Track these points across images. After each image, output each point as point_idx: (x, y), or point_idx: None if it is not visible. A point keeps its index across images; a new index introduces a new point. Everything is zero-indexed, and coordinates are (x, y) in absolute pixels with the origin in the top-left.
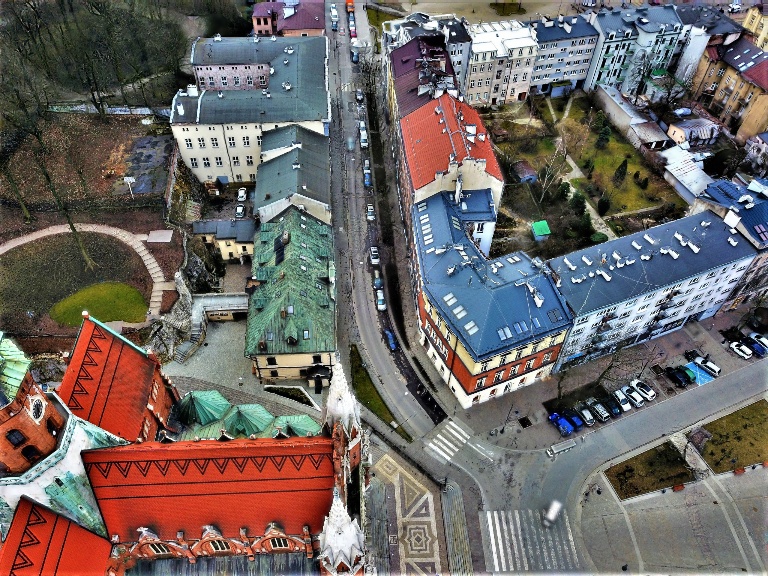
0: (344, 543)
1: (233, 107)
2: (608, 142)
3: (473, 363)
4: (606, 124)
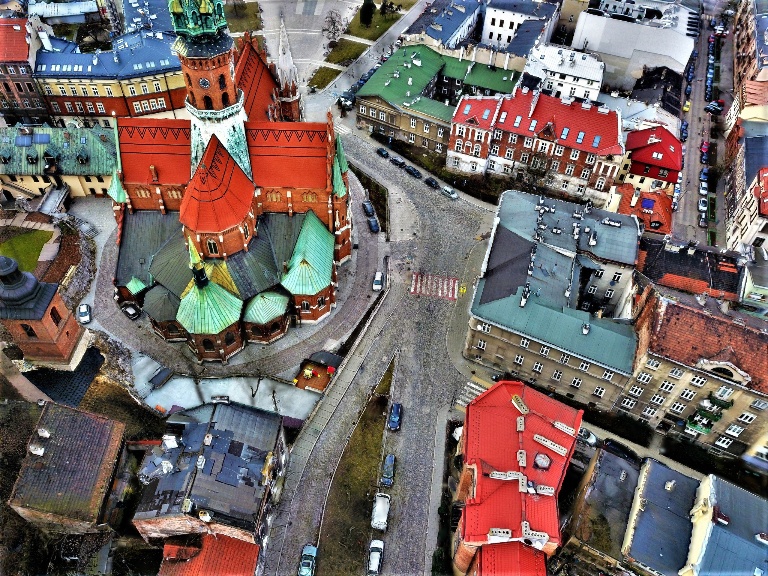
0: None
1: None
2: None
3: None
4: None
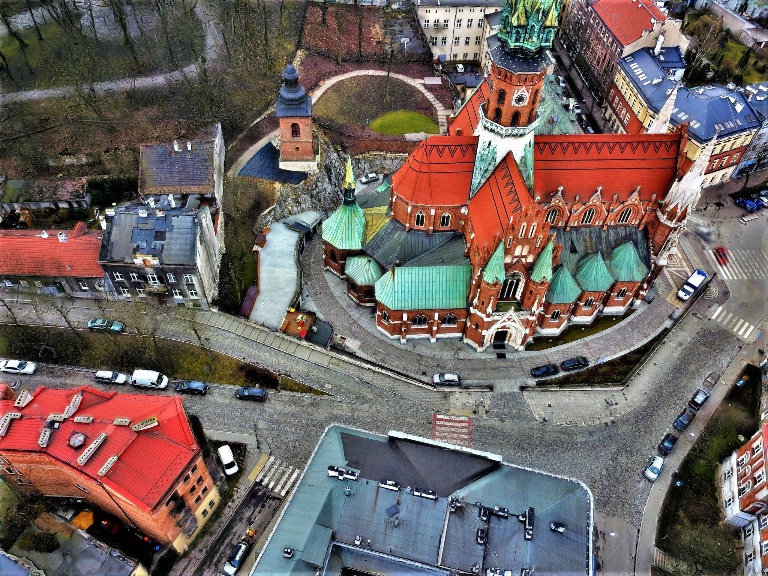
0: (697, 186)
1: None
2: (728, 41)
3: (696, 149)
4: (721, 30)
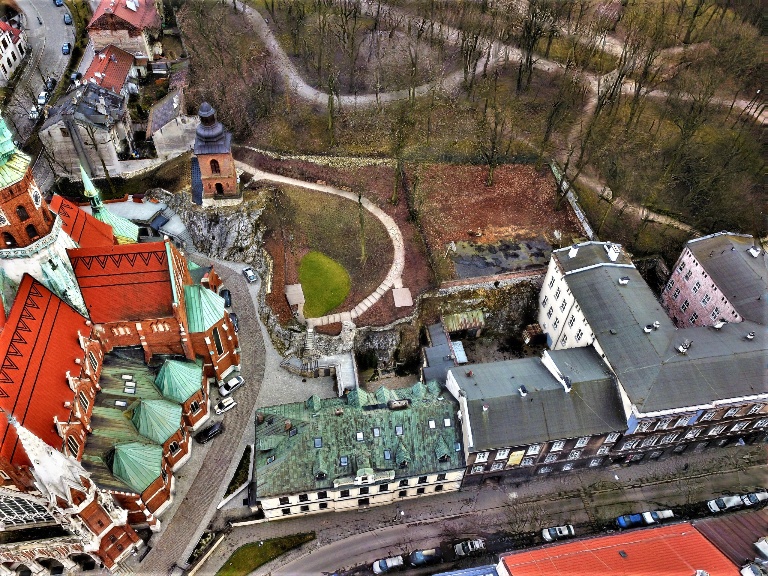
0: None
1: (608, 299)
2: None
3: None
4: None
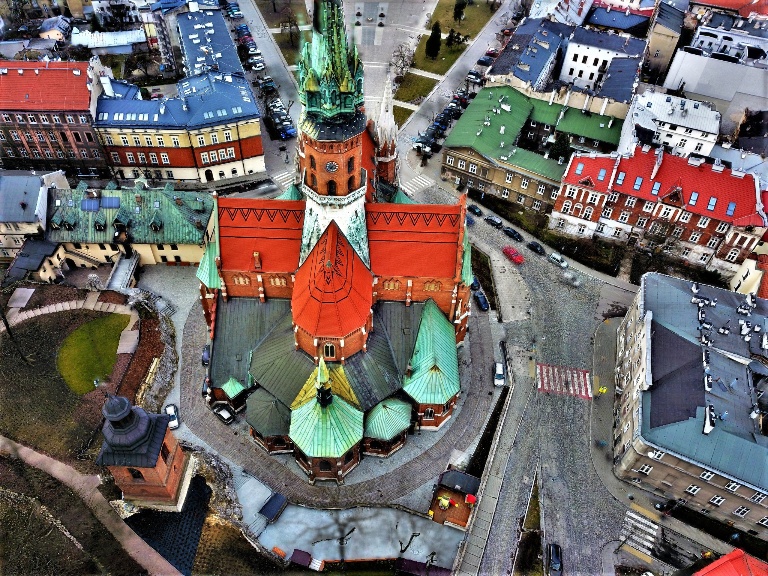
0: None
1: None
2: None
3: (257, 125)
4: None
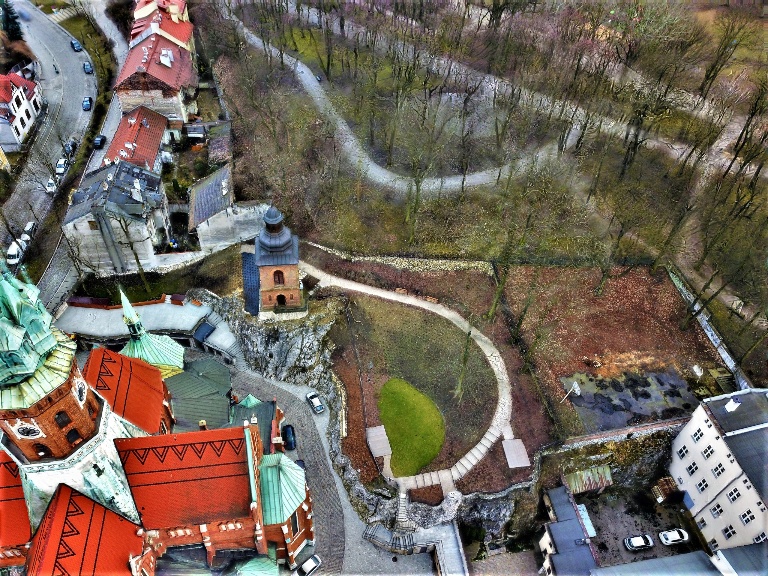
0: None
1: None
2: None
3: None
4: None
